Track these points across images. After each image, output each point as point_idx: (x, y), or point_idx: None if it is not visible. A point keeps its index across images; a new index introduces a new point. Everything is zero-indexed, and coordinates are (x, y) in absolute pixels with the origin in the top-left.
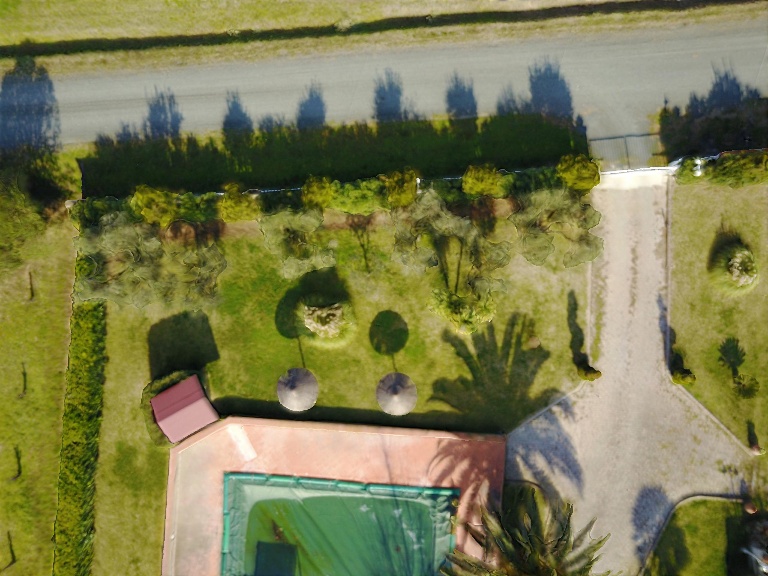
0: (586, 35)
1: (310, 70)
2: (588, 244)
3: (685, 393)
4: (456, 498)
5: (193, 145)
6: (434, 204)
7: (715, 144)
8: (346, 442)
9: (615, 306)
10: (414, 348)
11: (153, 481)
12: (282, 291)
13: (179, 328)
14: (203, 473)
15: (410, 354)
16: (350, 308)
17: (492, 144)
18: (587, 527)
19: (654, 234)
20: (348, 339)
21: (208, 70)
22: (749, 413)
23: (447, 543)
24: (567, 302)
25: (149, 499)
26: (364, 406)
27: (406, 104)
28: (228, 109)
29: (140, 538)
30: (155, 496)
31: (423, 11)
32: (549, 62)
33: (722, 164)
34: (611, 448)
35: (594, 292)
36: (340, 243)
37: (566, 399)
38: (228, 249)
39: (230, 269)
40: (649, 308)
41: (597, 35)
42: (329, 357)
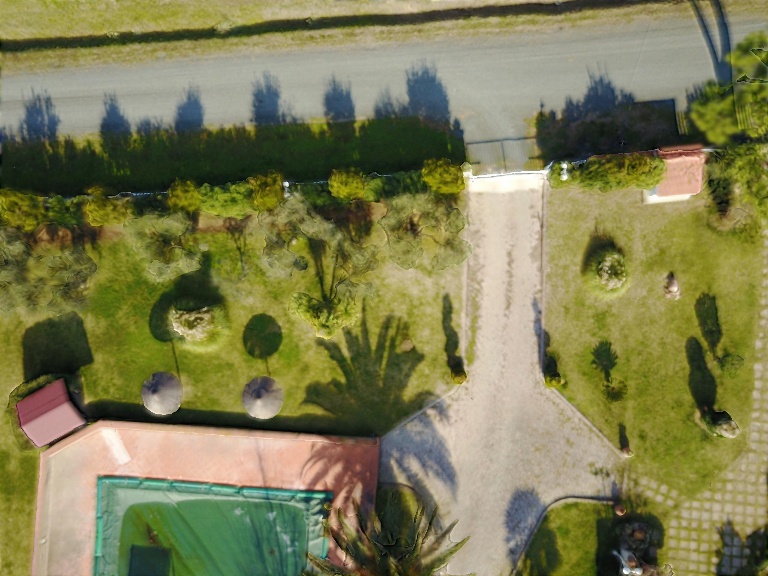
0: (463, 39)
1: (188, 72)
2: (452, 248)
3: (558, 396)
4: (328, 501)
5: (71, 147)
6: (299, 208)
7: (591, 148)
8: (220, 445)
9: (491, 309)
10: (288, 351)
11: (26, 485)
12: (157, 294)
13: (54, 331)
14: (77, 476)
15: (284, 357)
16: (222, 311)
17: (370, 147)
18: (446, 530)
19: (530, 237)
20: (221, 342)
21: (85, 72)
22: (621, 416)
23: (320, 546)
24: (442, 305)
25: (22, 503)
26: (237, 409)
27: (284, 107)
28: (105, 111)
29: (13, 542)
30: (28, 500)
31: (303, 14)
32: (426, 65)
33: (588, 168)
34: (485, 451)
35: (470, 295)
36: (216, 246)
37: (441, 402)
38: (105, 252)
39: (105, 272)
40: (524, 311)
41: (474, 39)
42: (203, 360)
